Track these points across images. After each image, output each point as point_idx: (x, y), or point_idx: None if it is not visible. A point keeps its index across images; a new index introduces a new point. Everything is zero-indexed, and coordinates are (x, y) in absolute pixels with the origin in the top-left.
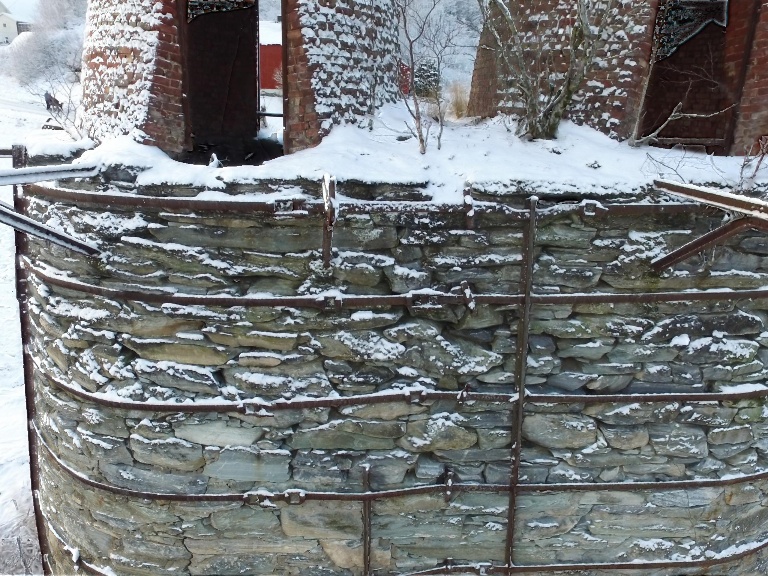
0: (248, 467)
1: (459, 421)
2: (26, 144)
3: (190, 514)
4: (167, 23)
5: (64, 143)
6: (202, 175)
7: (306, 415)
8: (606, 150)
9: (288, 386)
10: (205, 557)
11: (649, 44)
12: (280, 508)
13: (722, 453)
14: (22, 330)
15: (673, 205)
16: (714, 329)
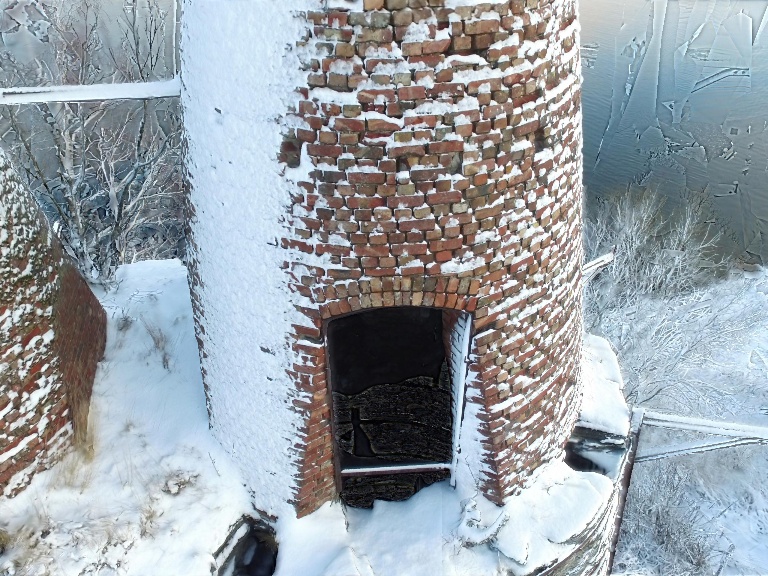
0: None
1: None
2: None
3: None
4: None
5: None
6: None
7: None
8: None
9: None
10: None
11: None
12: None
13: None
14: None
15: None
16: None
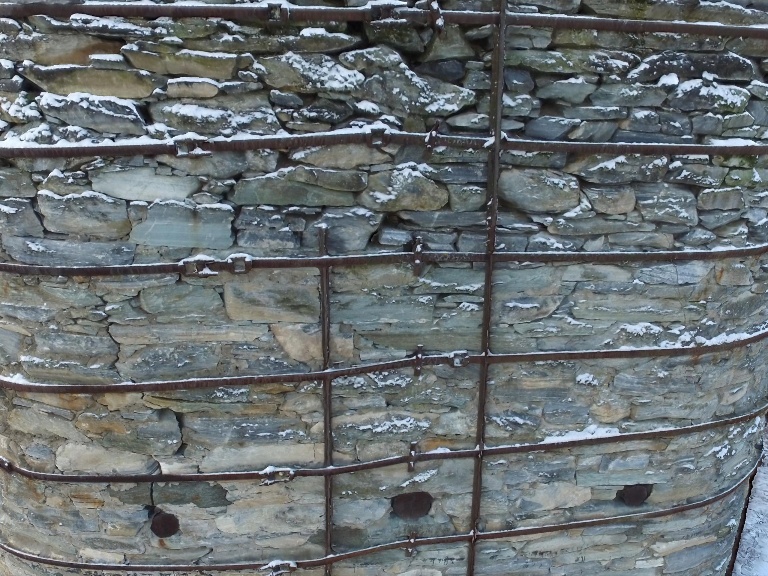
0: (183, 228)
1: (428, 172)
2: None
3: (115, 293)
4: None
5: None
6: None
7: (250, 160)
8: None
9: (227, 121)
10: (135, 348)
11: None
12: (223, 284)
13: (713, 220)
14: None
15: None
16: (704, 70)
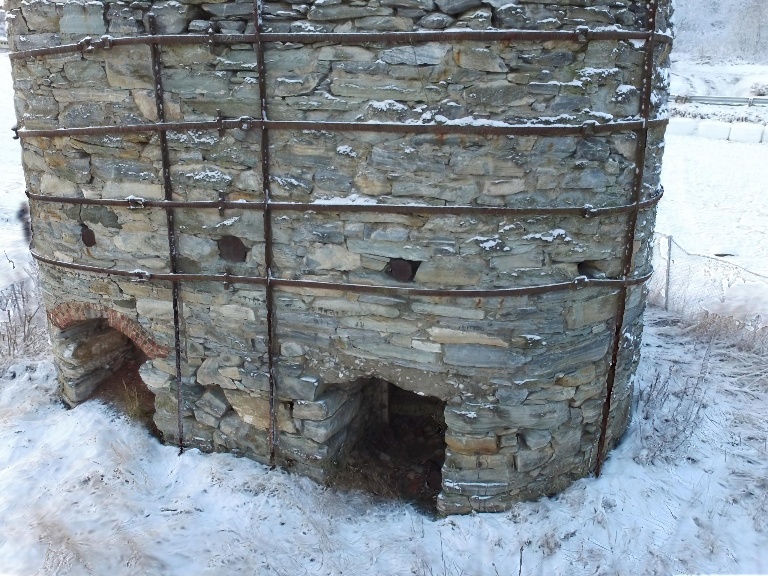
0: (80, 20)
1: None
2: None
3: (54, 66)
4: None
5: None
6: None
7: None
8: None
9: None
10: (64, 105)
11: None
12: (104, 60)
13: (444, 2)
14: None
15: None
16: None
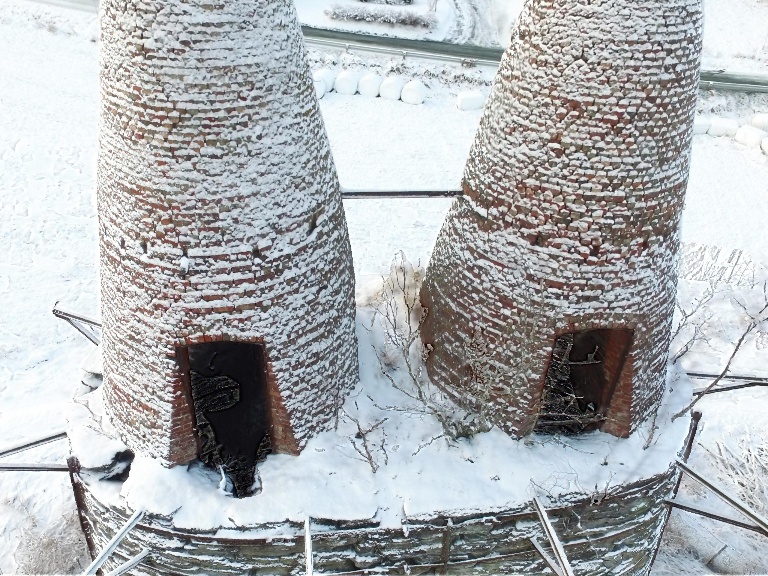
0: None
1: None
2: (77, 456)
3: None
4: (178, 398)
5: (105, 452)
6: (219, 517)
7: None
8: (506, 460)
9: None
10: None
11: (543, 382)
12: None
13: None
14: (89, 545)
15: (546, 510)
16: (573, 560)
